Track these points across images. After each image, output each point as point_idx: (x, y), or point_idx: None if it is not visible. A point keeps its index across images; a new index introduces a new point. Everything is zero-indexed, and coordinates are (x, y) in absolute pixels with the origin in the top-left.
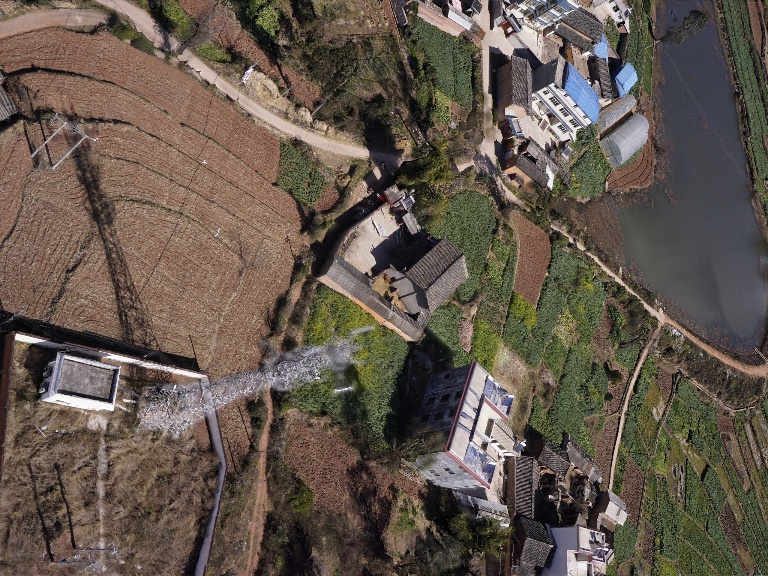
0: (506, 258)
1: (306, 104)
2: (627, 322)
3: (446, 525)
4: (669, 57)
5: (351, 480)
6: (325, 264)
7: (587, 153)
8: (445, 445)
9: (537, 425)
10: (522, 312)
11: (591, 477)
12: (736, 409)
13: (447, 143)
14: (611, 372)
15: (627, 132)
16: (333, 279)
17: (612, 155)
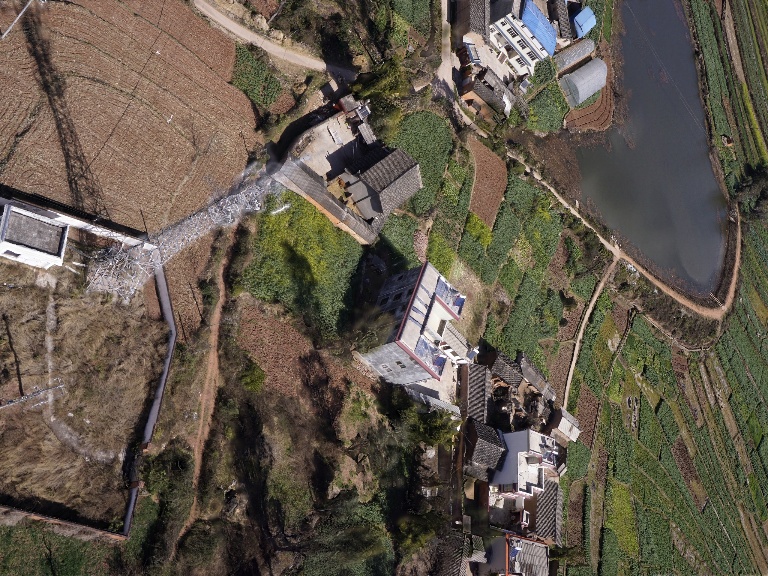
0: (462, 179)
1: (263, 15)
2: (583, 255)
3: (398, 418)
4: (628, 7)
5: (303, 367)
6: (279, 163)
7: (545, 90)
8: (396, 335)
9: (492, 340)
10: (477, 231)
11: (545, 395)
12: (690, 349)
13: (404, 62)
14: (566, 299)
15: (585, 73)
16: (287, 176)
17: (570, 94)
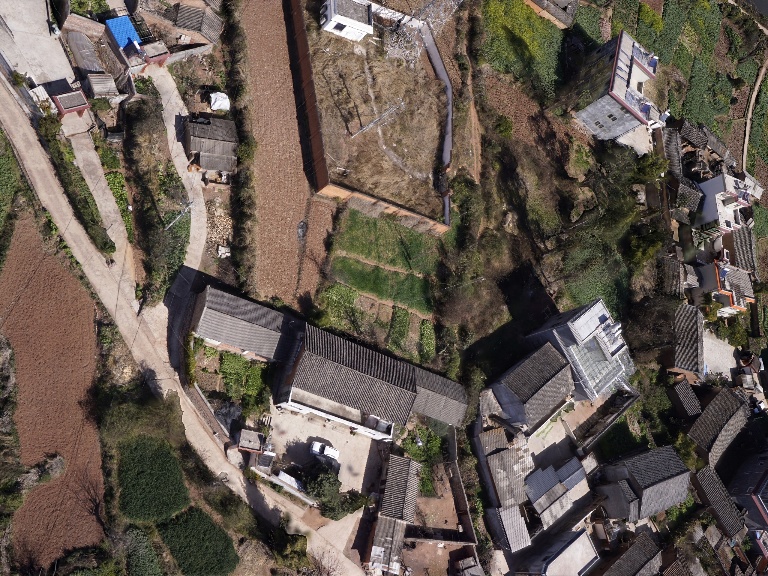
0: None
1: None
2: (743, 43)
3: None
4: None
5: (536, 124)
6: None
7: None
8: (608, 88)
9: (674, 114)
10: (650, 18)
11: (726, 161)
12: None
13: None
14: (734, 80)
15: None
16: None
17: None
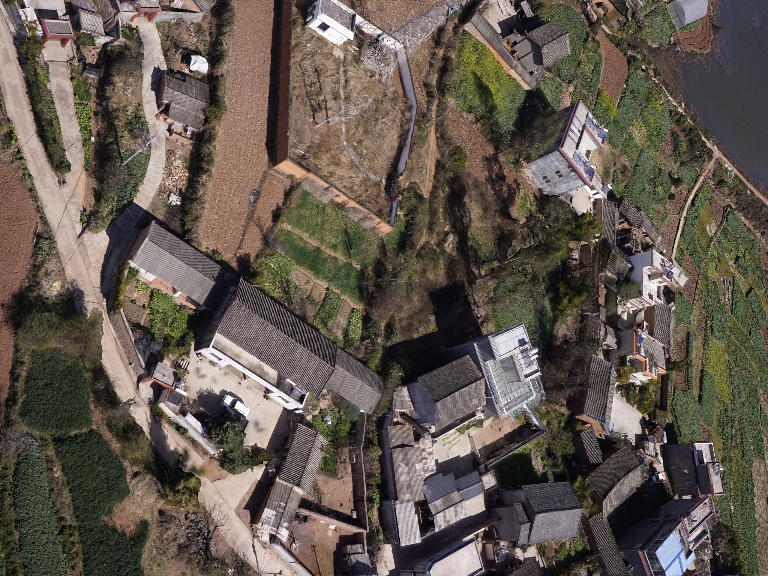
0: (594, 63)
1: None
2: (687, 149)
3: (555, 217)
4: None
5: (489, 164)
6: (468, 18)
7: (657, 9)
8: (559, 145)
9: (616, 193)
10: (606, 104)
11: (658, 247)
12: None
13: None
14: (674, 178)
15: (690, 0)
16: (475, 25)
17: (677, 17)
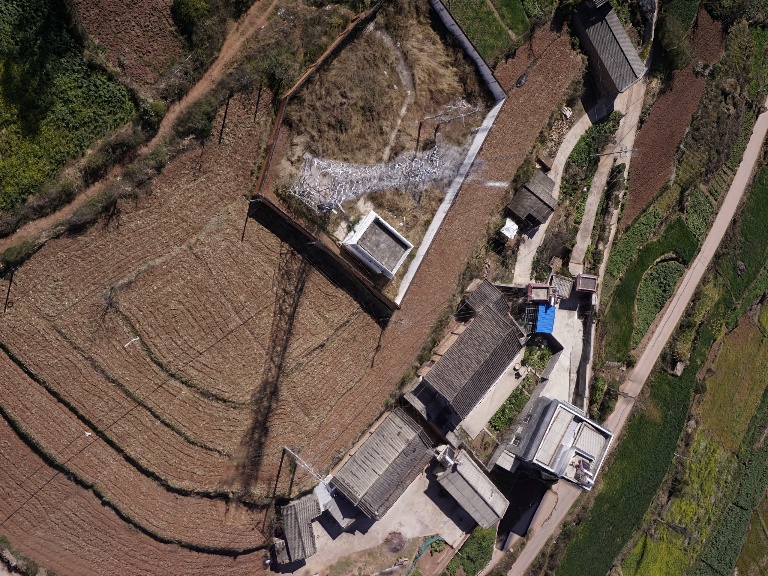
0: None
1: None
2: None
3: None
4: None
5: None
6: None
7: None
8: None
9: None
10: None
11: None
12: None
13: None
14: None
15: None
16: None
17: None
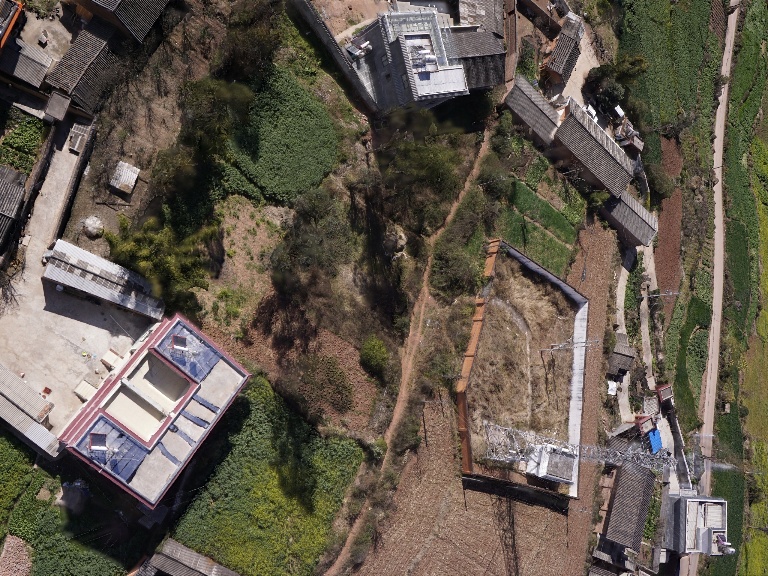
0: None
1: None
2: None
3: None
4: None
5: (303, 361)
6: None
7: None
8: None
9: None
10: None
11: None
12: None
13: None
14: None
15: None
16: None
17: None
